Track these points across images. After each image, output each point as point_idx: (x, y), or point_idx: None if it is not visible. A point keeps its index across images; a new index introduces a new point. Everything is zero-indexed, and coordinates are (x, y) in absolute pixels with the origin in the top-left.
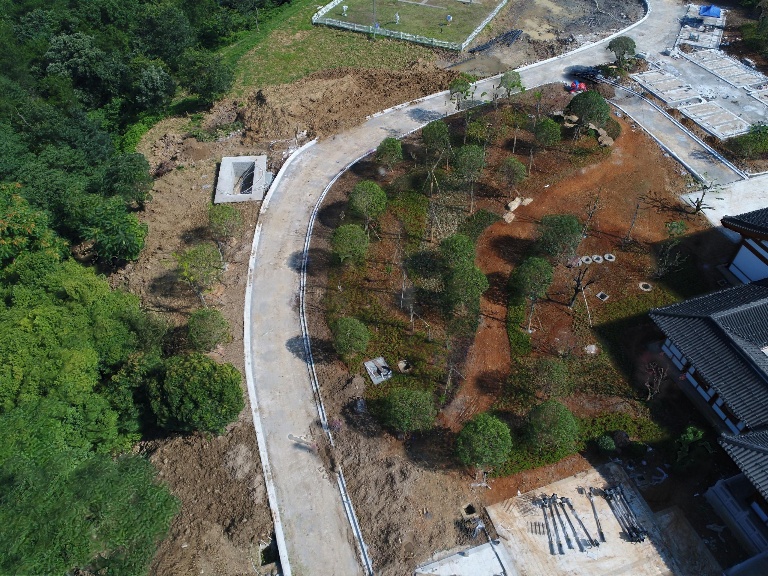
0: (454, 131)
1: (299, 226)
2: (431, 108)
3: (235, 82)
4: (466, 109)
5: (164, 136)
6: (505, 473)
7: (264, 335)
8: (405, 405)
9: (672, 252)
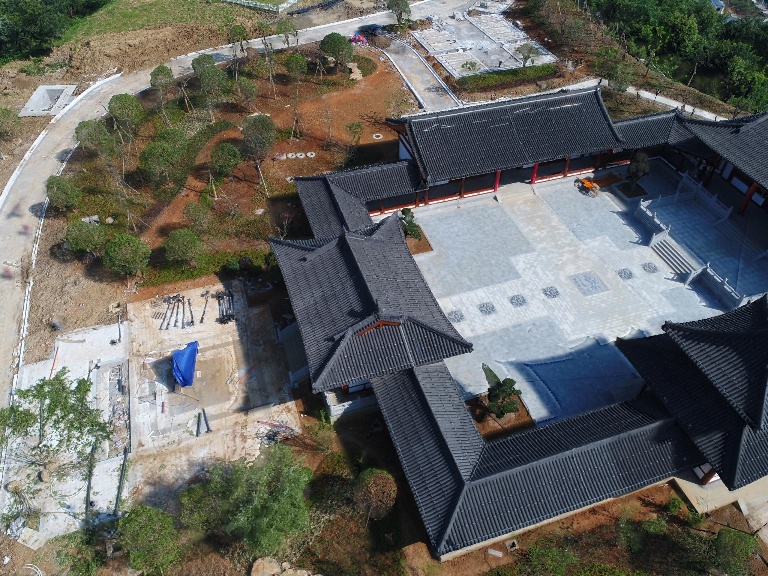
0: (232, 67)
1: None
2: (229, 53)
3: (77, 33)
4: None
5: (3, 72)
6: (151, 284)
7: (15, 201)
8: (73, 229)
9: (364, 152)
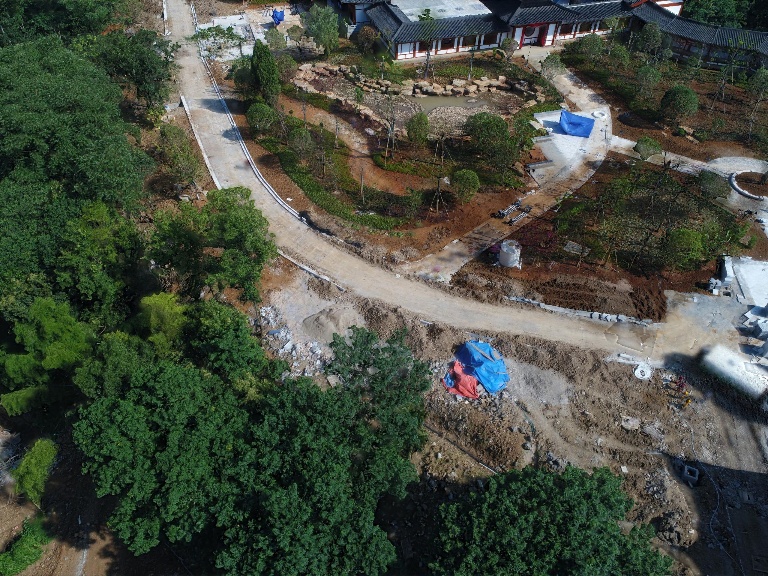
0: None
1: None
2: None
3: None
4: None
5: None
6: (255, 4)
7: None
8: None
9: None
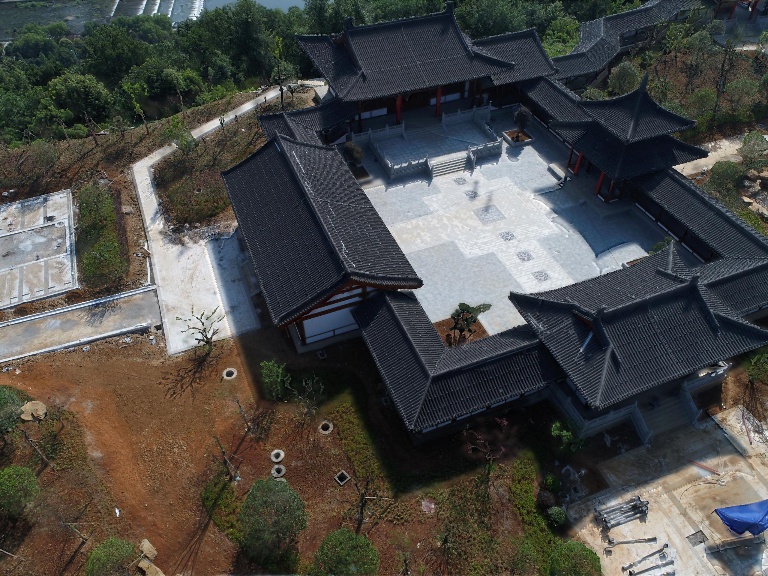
0: None
1: None
2: None
3: None
4: None
5: None
6: None
7: None
8: None
9: None
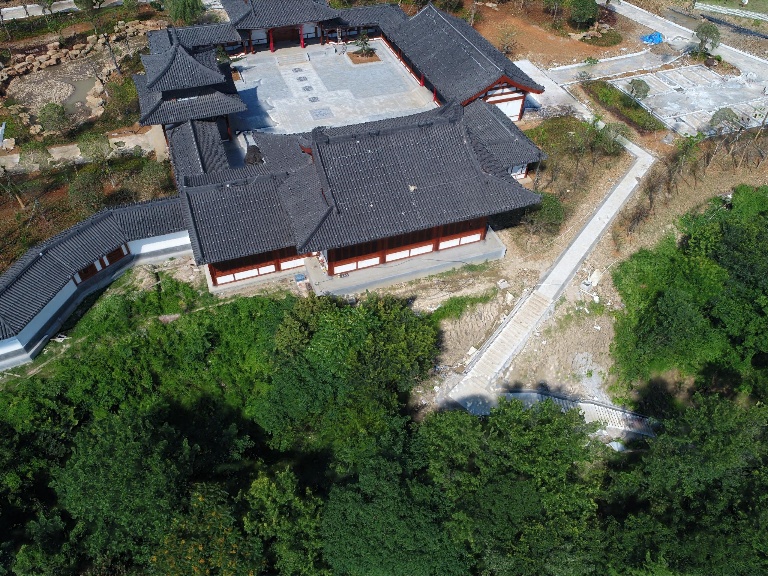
0: None
1: None
2: None
3: None
4: (599, 4)
5: None
6: None
7: None
8: None
9: None
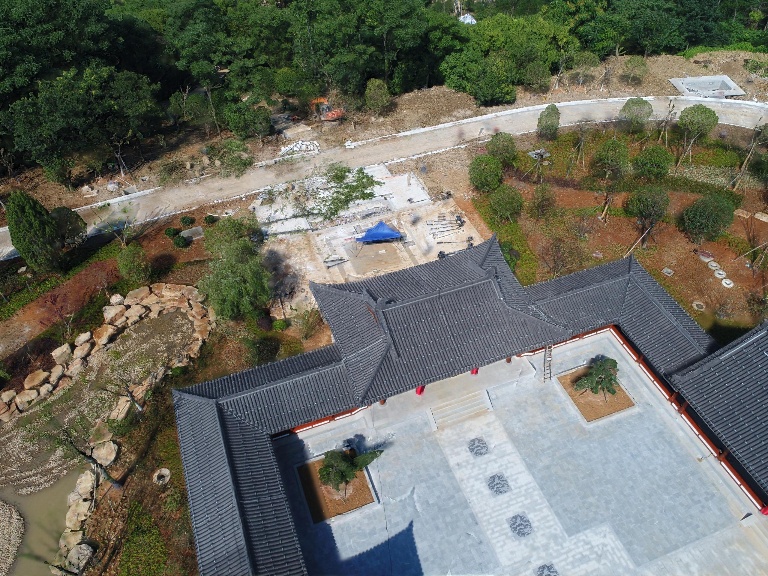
0: None
1: (665, 115)
2: None
3: None
4: None
5: None
6: None
7: None
8: (498, 135)
9: None
